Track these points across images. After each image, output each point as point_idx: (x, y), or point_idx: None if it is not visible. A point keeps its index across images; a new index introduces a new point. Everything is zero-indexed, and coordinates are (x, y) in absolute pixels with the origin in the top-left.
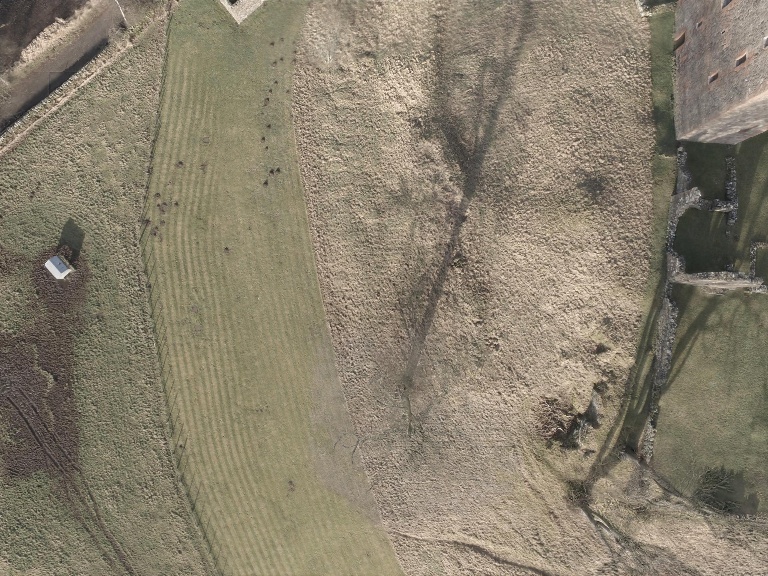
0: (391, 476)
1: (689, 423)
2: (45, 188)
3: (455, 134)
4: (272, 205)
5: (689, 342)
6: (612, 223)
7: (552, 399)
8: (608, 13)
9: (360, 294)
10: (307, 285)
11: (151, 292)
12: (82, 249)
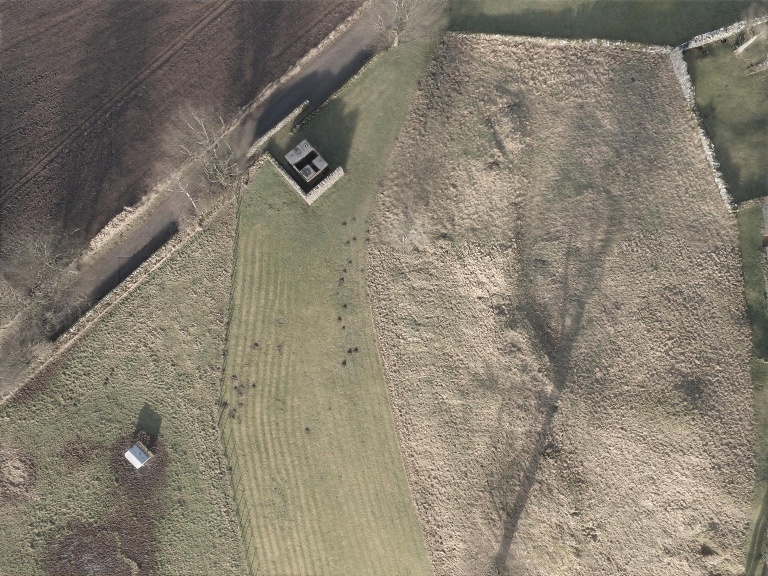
0: None
1: None
2: (119, 374)
3: (540, 322)
4: (352, 385)
5: None
6: (714, 428)
7: None
8: (694, 208)
9: (446, 474)
10: (391, 464)
11: (232, 475)
12: (160, 434)
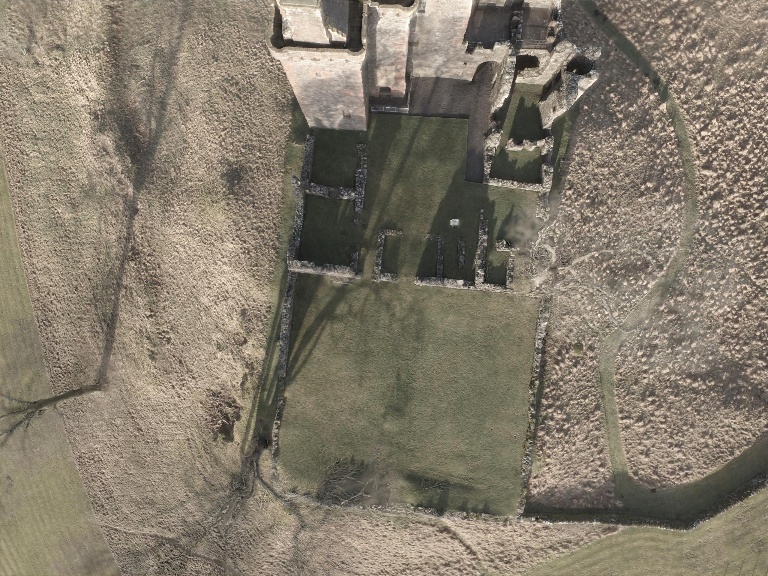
0: (98, 470)
1: (318, 414)
2: None
3: (130, 126)
4: None
5: (316, 332)
6: (246, 213)
7: (217, 391)
8: None
9: (62, 289)
10: (15, 281)
11: None
12: None
